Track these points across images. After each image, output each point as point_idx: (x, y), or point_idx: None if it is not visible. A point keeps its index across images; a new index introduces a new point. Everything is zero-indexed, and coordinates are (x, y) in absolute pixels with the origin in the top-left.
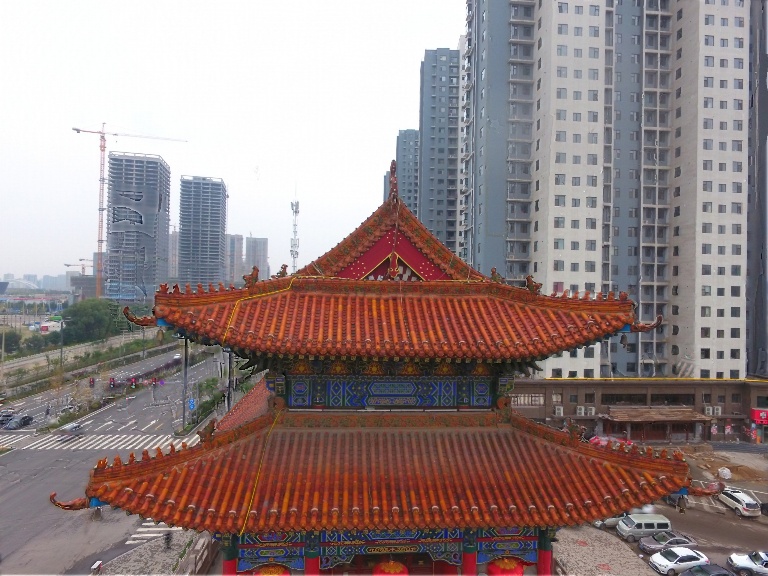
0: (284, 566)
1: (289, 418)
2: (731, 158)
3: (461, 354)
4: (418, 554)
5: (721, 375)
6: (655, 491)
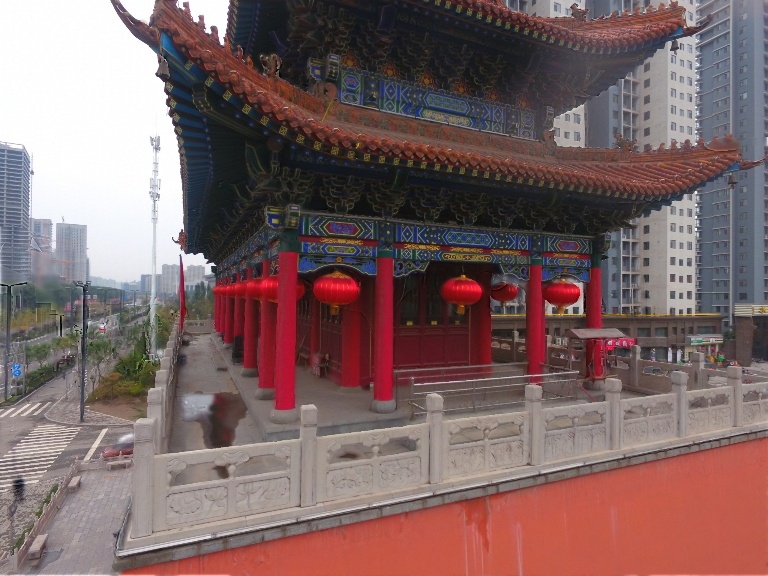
0: (352, 272)
1: (343, 111)
2: (573, 128)
3: (549, 28)
4: (455, 313)
5: (566, 312)
6: (715, 166)
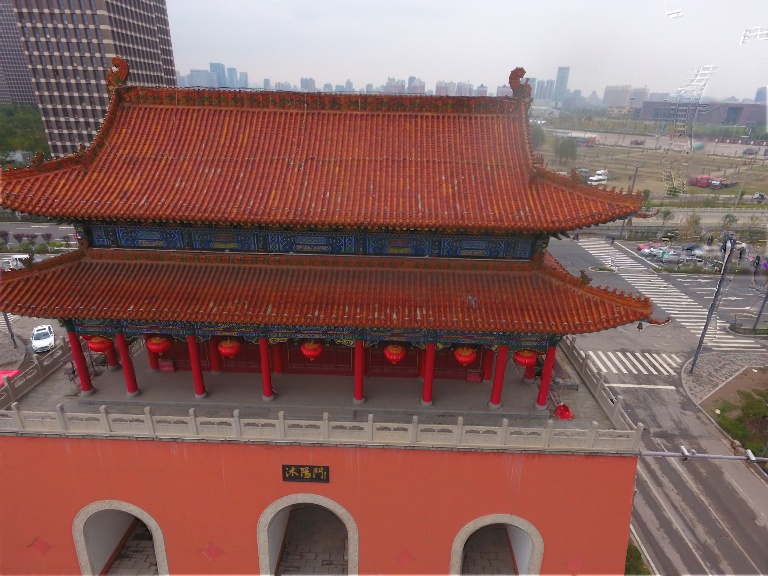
0: None
1: None
2: None
3: None
4: None
5: None
6: None
